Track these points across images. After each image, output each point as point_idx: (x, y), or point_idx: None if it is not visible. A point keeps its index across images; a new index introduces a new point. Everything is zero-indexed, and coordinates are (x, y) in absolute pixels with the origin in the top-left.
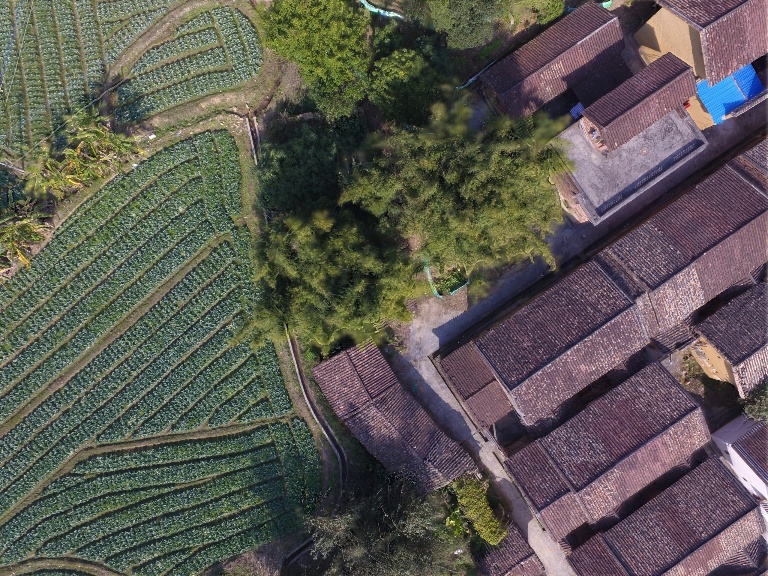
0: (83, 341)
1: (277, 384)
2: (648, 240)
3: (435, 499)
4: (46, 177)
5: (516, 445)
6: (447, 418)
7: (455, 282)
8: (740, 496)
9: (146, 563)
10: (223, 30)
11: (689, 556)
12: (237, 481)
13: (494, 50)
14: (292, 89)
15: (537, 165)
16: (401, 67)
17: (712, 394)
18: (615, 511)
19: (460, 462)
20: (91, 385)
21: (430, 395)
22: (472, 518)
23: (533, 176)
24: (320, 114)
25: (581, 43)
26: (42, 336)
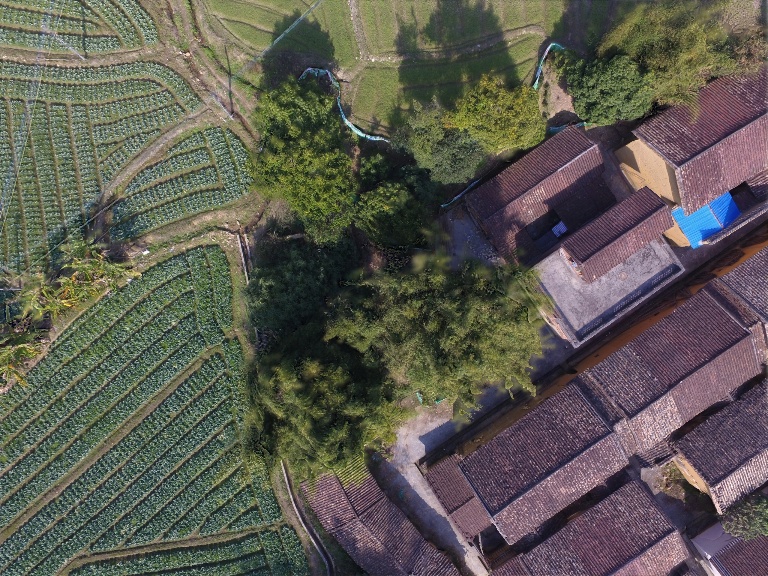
0: (78, 452)
1: (267, 493)
2: (627, 365)
3: None
4: (42, 304)
5: (500, 555)
6: (433, 523)
7: None
8: None
9: None
10: (215, 150)
11: None
12: None
13: (478, 169)
14: (282, 207)
15: (514, 321)
16: (386, 202)
17: (693, 499)
18: None
19: (445, 573)
20: (85, 495)
21: (416, 501)
22: None
23: (510, 331)
24: (308, 236)
25: (562, 170)
26: (38, 448)
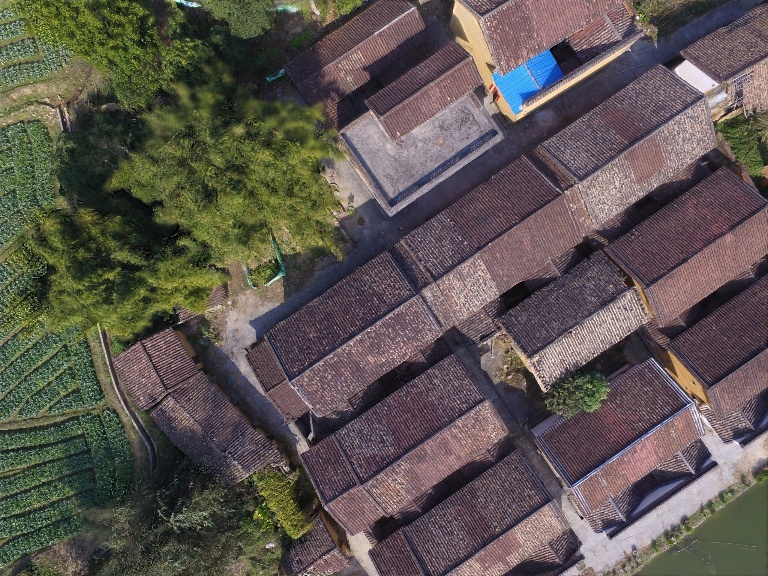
0: None
1: (88, 375)
2: (440, 231)
3: (244, 492)
4: None
5: (324, 438)
6: (264, 411)
7: (270, 274)
8: (536, 491)
9: None
10: (34, 21)
11: (482, 551)
12: (46, 472)
13: (305, 41)
14: (102, 80)
15: (275, 152)
16: (184, 56)
17: (534, 388)
18: (418, 505)
19: (264, 455)
20: None
21: (247, 388)
22: (273, 511)
23: (271, 163)
24: (121, 104)
25: (379, 33)
26: None
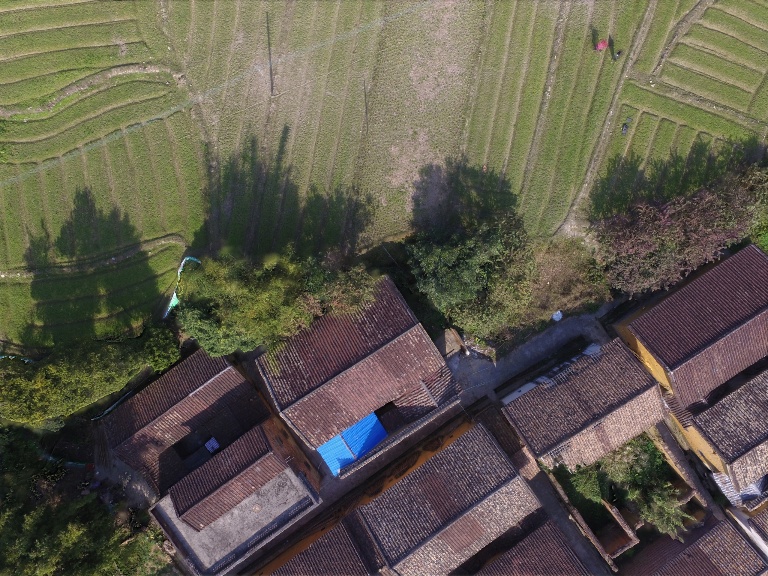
0: None
1: None
2: None
3: None
4: None
5: None
6: None
7: None
8: None
9: None
10: None
11: None
12: None
13: (130, 380)
14: None
15: None
16: None
17: None
18: None
19: None
20: None
21: None
22: None
23: None
24: None
25: (194, 394)
26: None
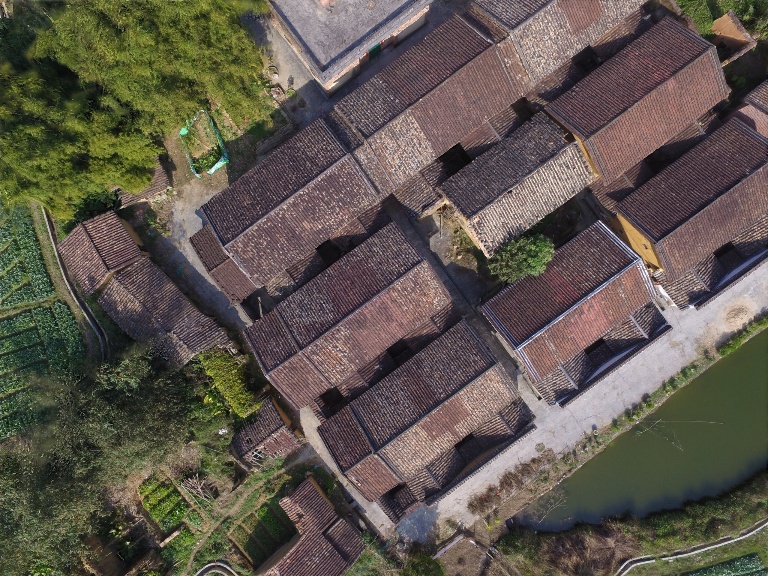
0: None
1: (38, 268)
2: (372, 93)
3: (194, 377)
4: None
5: None
6: (214, 300)
7: (212, 160)
8: (482, 356)
9: None
10: None
11: (428, 418)
12: (1, 365)
13: None
14: None
15: None
16: None
17: (485, 268)
18: (365, 380)
19: (210, 336)
20: None
21: (195, 277)
22: (221, 391)
23: (181, 1)
24: None
25: None
26: None
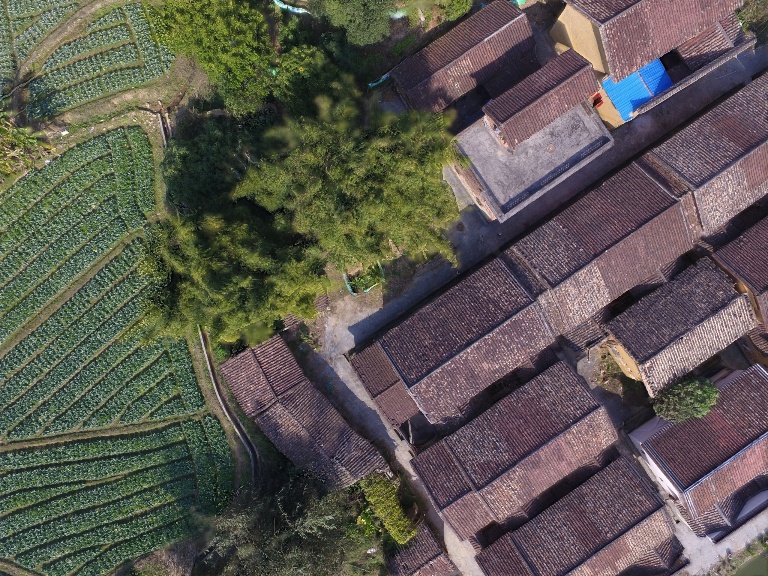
0: None
1: (189, 381)
2: (552, 237)
3: (347, 498)
4: None
5: (427, 444)
6: (362, 416)
7: (369, 280)
8: (647, 496)
9: (56, 560)
10: (135, 26)
11: (594, 556)
12: (148, 478)
13: (407, 47)
14: (204, 85)
15: (417, 161)
16: (301, 63)
17: (631, 393)
18: (524, 510)
19: (369, 460)
20: (2, 381)
21: (345, 393)
22: (380, 517)
23: (413, 172)
24: (228, 110)
25: (488, 39)
26: None
